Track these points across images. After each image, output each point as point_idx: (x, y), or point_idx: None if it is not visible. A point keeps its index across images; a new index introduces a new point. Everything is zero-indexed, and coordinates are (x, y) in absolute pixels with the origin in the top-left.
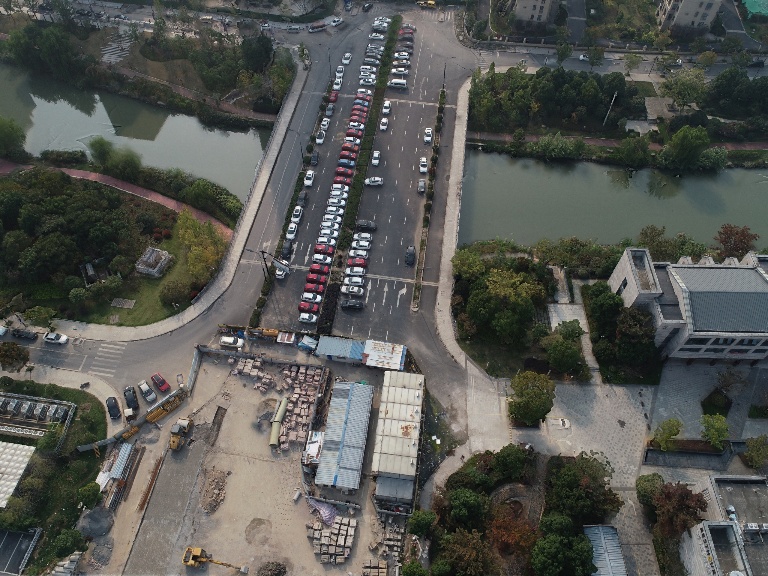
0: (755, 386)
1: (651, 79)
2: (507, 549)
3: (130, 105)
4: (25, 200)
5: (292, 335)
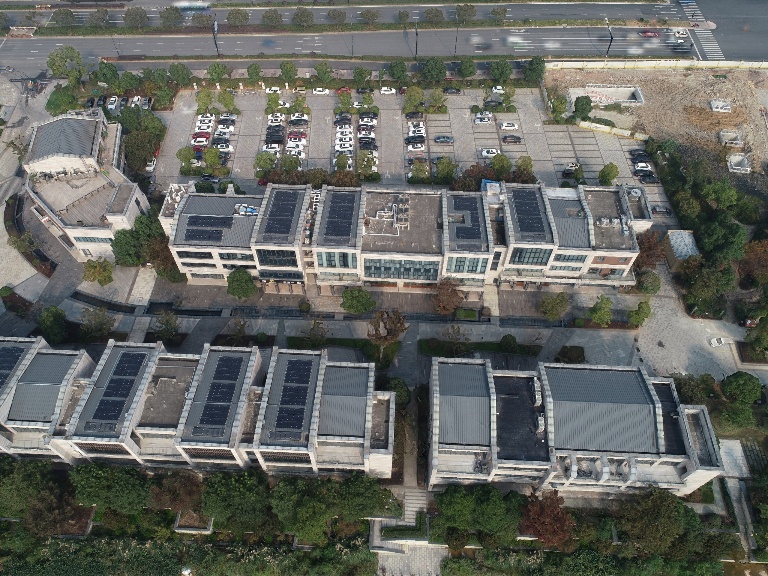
0: None
1: None
2: (746, 262)
3: None
4: None
5: None
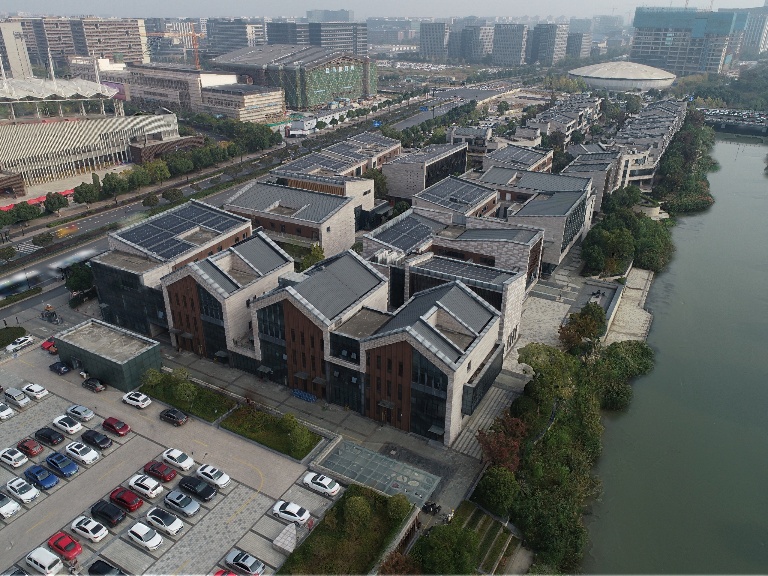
0: None
1: None
2: None
3: None
4: (721, 88)
5: None
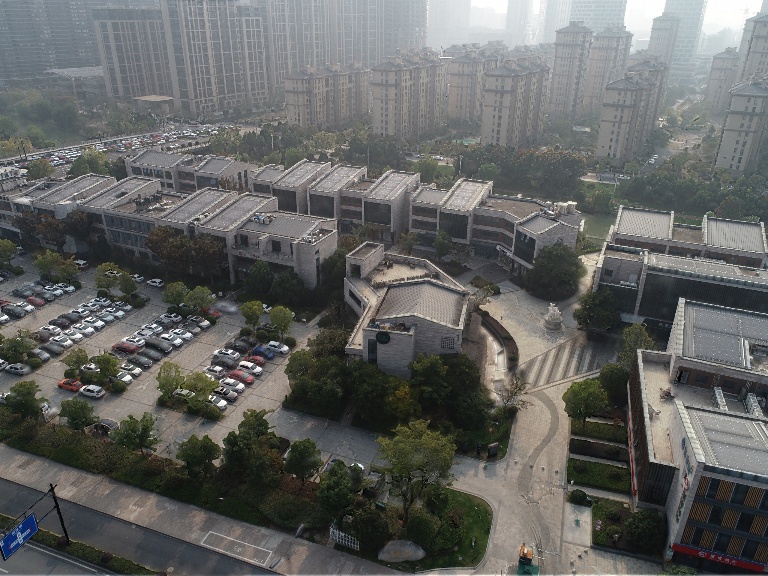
0: None
1: (332, 151)
2: None
3: (78, 137)
4: None
5: (2, 166)
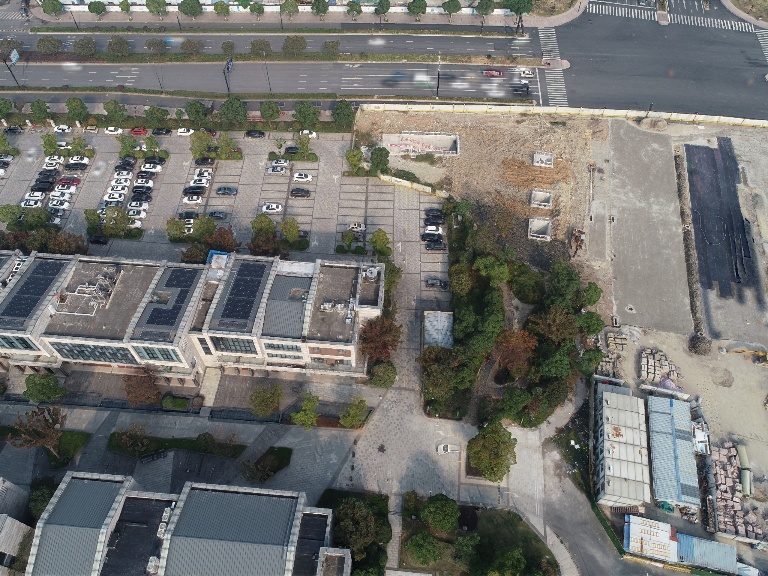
0: (218, 481)
1: None
2: None
3: None
4: None
5: None
